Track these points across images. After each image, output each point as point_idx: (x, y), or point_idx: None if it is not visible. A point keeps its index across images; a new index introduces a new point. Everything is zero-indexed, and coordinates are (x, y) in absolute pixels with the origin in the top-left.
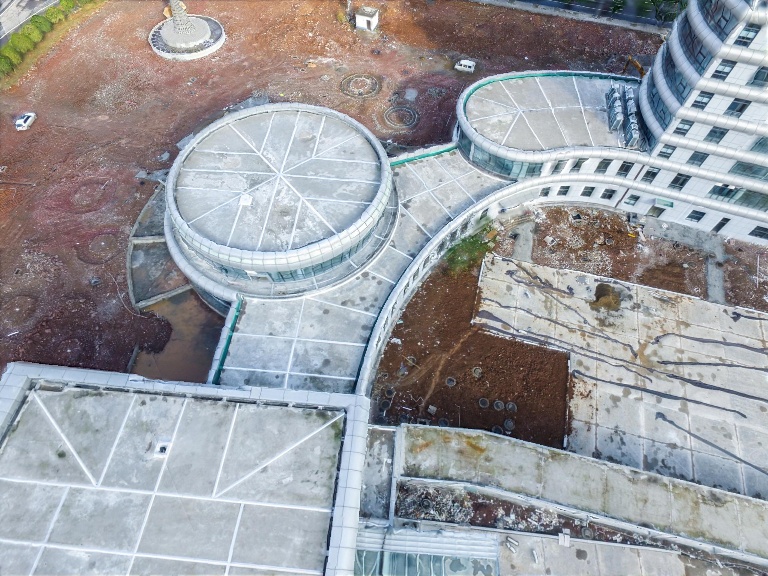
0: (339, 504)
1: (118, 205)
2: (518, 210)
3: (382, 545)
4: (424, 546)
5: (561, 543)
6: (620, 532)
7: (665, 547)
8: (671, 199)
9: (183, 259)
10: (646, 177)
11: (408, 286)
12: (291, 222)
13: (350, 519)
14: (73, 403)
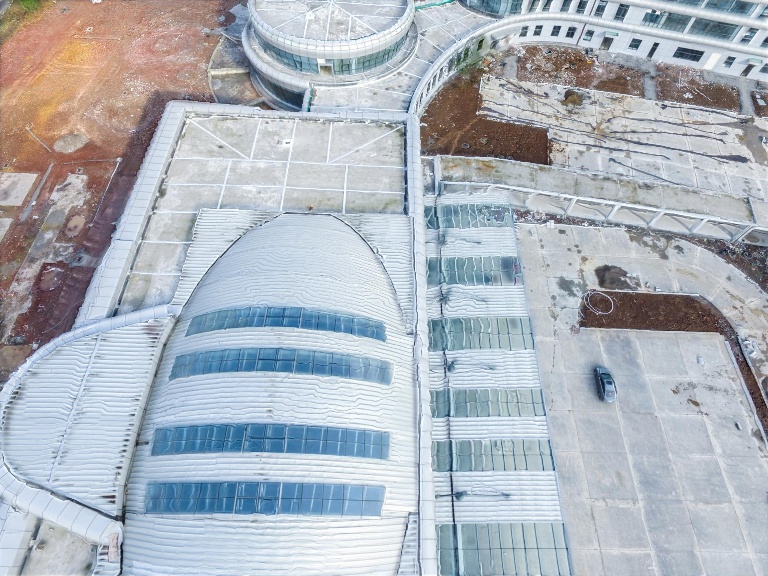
0: (410, 161)
1: (192, 50)
2: (505, 47)
3: (435, 204)
4: (462, 200)
5: (548, 226)
6: (587, 220)
7: (616, 226)
8: (617, 30)
9: (264, 64)
10: (598, 12)
11: (429, 89)
12: (346, 29)
13: (418, 169)
14: (219, 124)
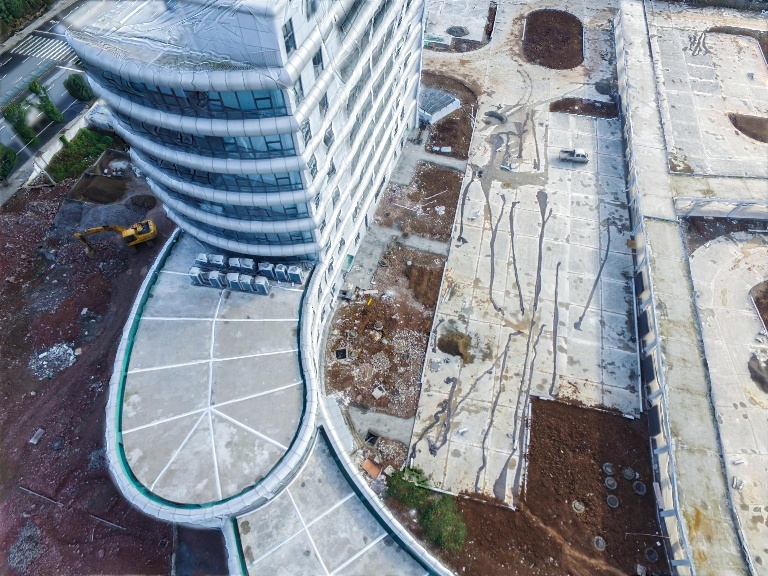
0: None
1: None
2: None
3: None
4: None
5: None
6: None
7: None
8: None
9: None
10: None
11: None
12: None
13: None
14: None
